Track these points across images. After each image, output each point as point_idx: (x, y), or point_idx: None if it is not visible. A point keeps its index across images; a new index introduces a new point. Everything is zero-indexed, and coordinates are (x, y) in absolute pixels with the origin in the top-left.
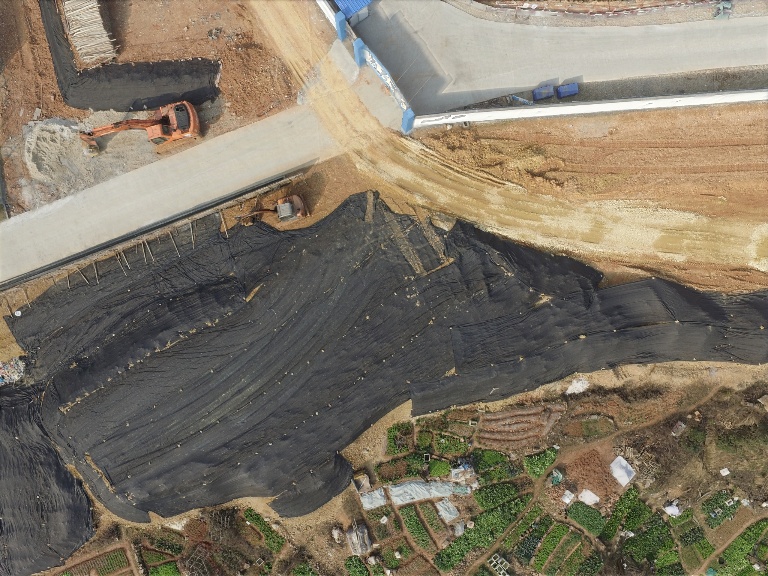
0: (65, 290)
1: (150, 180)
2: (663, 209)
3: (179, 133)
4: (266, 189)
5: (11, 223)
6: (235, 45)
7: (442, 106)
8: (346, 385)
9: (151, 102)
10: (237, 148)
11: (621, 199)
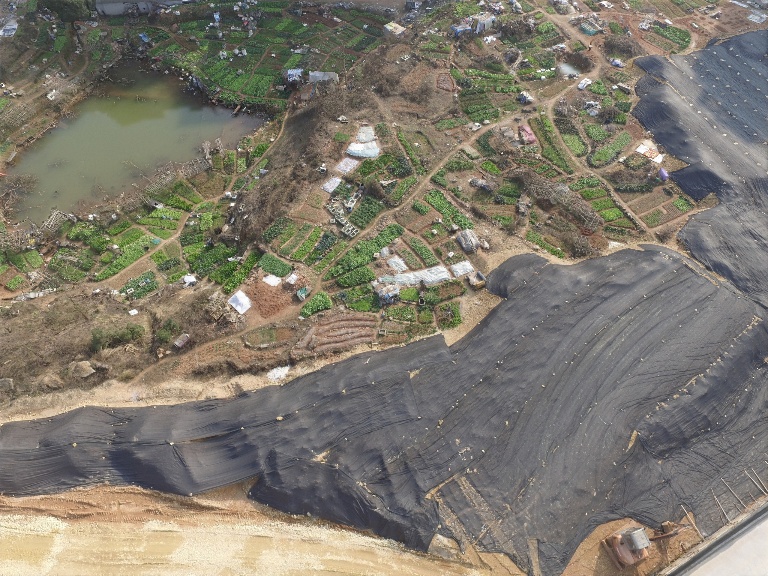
0: None
1: None
2: None
3: None
4: None
5: None
6: None
7: None
8: (513, 355)
9: None
10: None
11: None
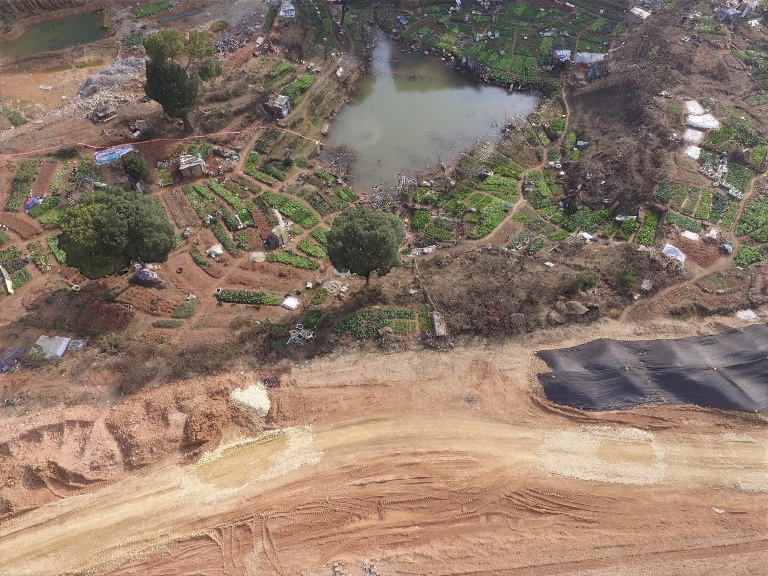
0: None
1: None
2: None
3: None
4: None
5: None
6: None
7: None
8: None
9: None
10: None
11: None
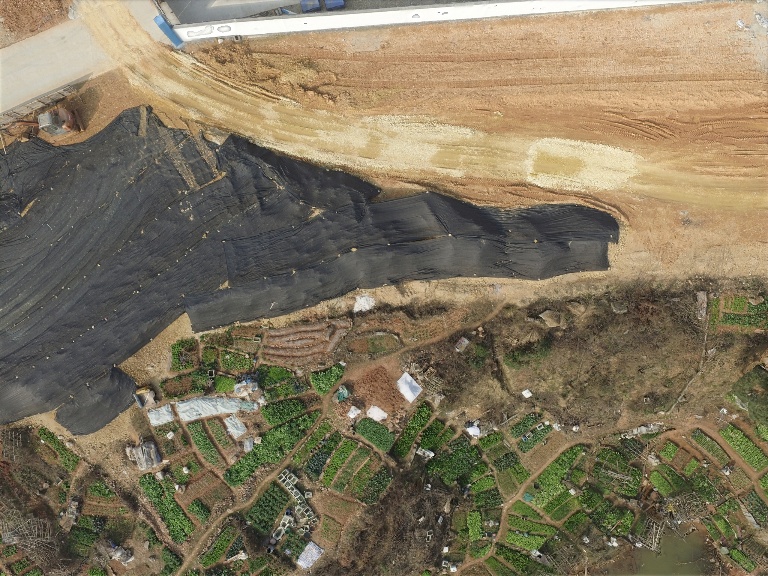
0: None
1: None
2: (439, 124)
3: None
4: (38, 104)
5: None
6: None
7: (212, 20)
8: (122, 299)
9: None
10: (12, 64)
11: (397, 114)
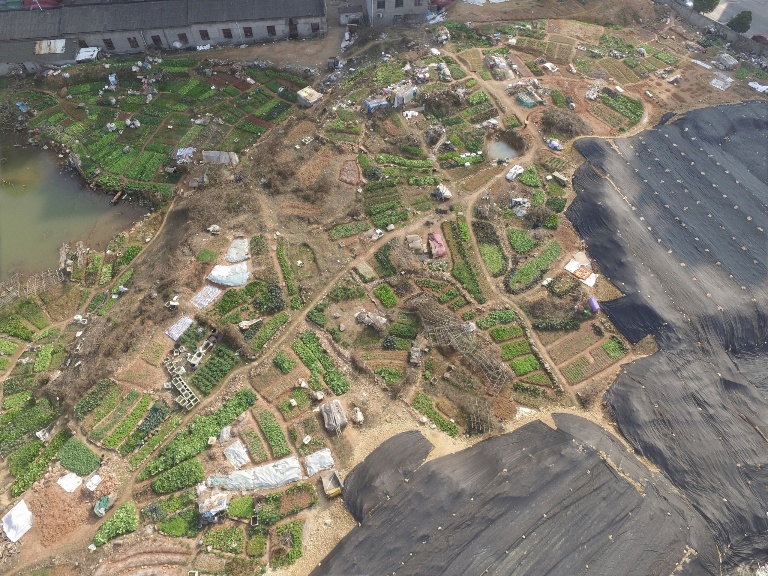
0: None
1: None
2: None
3: None
4: None
5: None
6: None
7: None
8: None
9: None
10: None
11: None
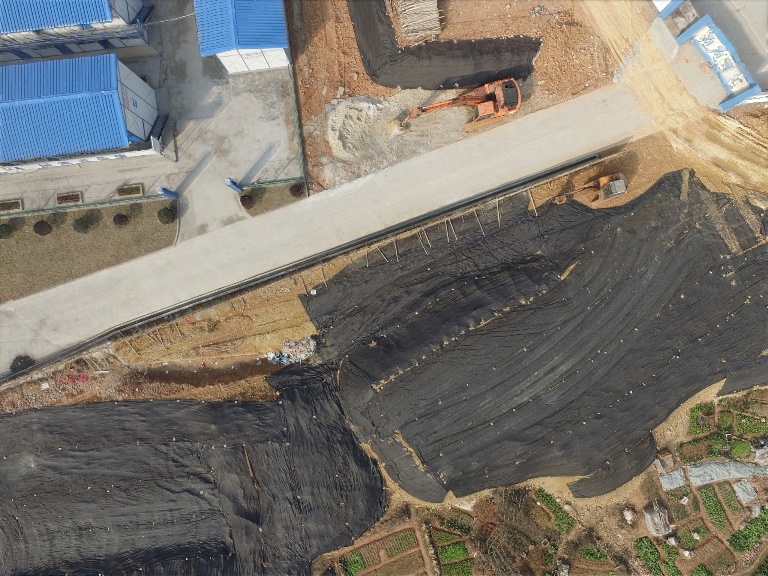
0: (363, 269)
1: (456, 158)
2: None
3: (506, 110)
4: None
5: (310, 201)
6: (557, 23)
7: (761, 84)
8: (661, 364)
9: (464, 80)
10: (548, 126)
11: None
